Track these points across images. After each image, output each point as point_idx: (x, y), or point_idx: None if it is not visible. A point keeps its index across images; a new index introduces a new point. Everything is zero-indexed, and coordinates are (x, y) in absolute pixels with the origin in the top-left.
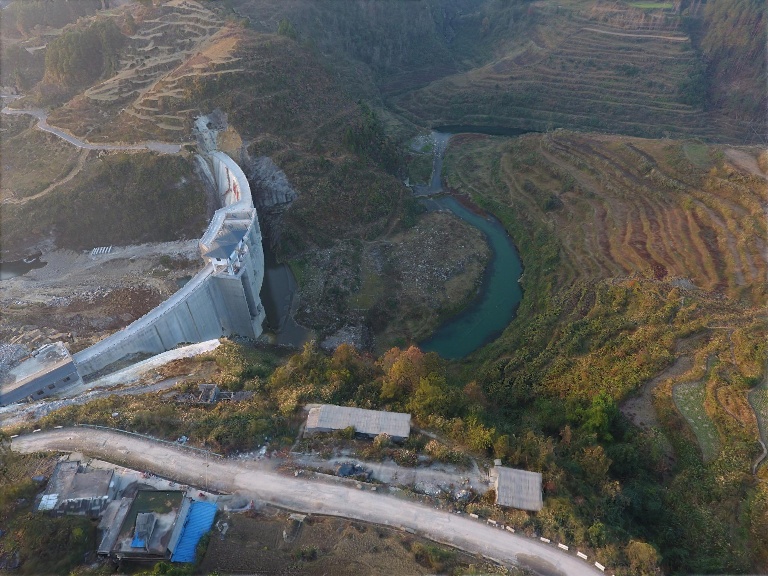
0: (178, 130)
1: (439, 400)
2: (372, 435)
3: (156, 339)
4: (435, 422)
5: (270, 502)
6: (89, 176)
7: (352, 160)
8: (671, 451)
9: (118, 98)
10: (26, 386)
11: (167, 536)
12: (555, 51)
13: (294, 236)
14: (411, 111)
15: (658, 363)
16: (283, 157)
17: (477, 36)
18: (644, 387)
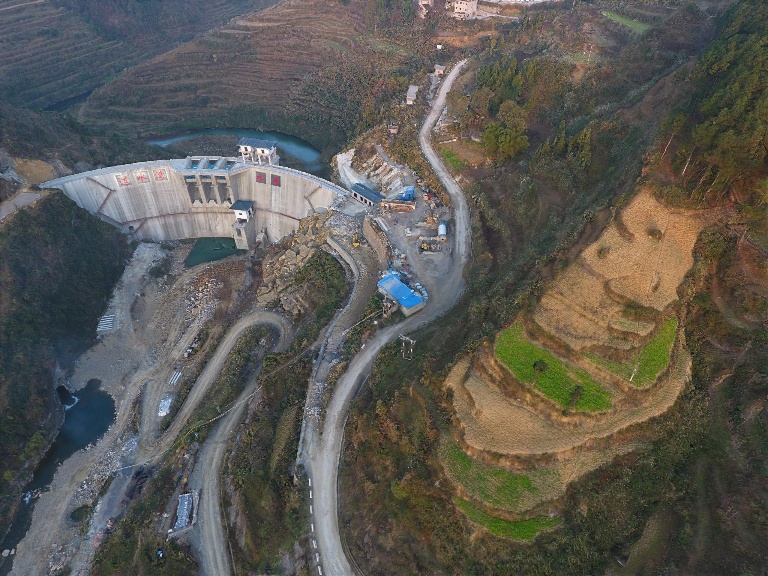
0: None
1: None
2: None
3: None
4: None
5: None
6: (1, 280)
7: None
8: None
9: None
10: None
11: None
12: None
13: None
14: None
15: None
16: (87, 154)
17: None
18: None
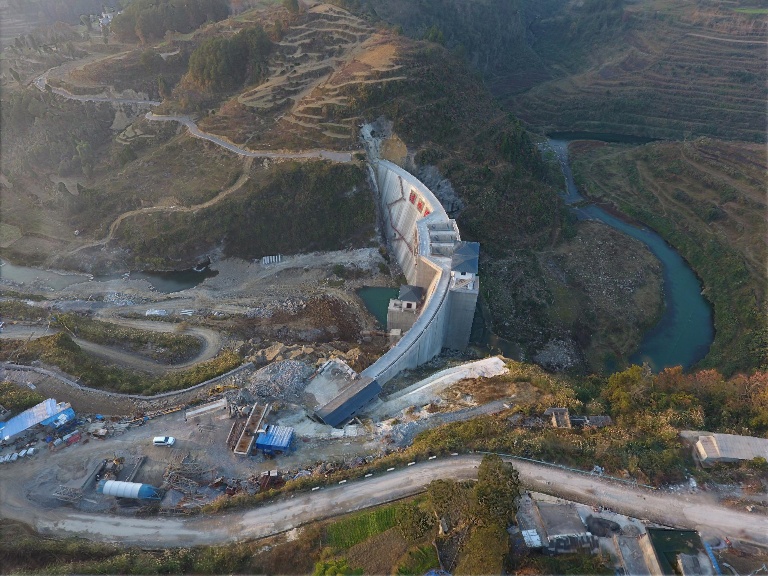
0: (345, 138)
1: None
2: None
3: (416, 355)
4: None
5: (743, 540)
6: (260, 184)
7: (510, 169)
8: None
9: (273, 105)
10: (344, 406)
11: None
12: (662, 57)
13: None
14: (519, 117)
15: None
16: (449, 166)
17: (563, 41)
18: None
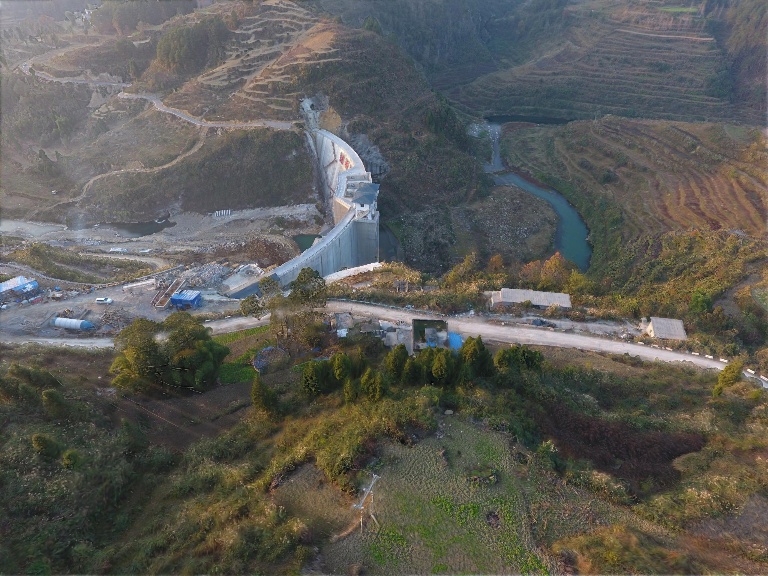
0: (287, 110)
1: (589, 284)
2: (544, 306)
3: (319, 266)
4: (588, 299)
5: (491, 339)
6: (213, 149)
7: (433, 138)
8: (756, 331)
9: (228, 84)
10: (248, 288)
11: (447, 342)
12: (592, 50)
13: (390, 201)
14: (462, 103)
15: (734, 278)
16: (377, 134)
17: (513, 38)
18: (727, 292)
